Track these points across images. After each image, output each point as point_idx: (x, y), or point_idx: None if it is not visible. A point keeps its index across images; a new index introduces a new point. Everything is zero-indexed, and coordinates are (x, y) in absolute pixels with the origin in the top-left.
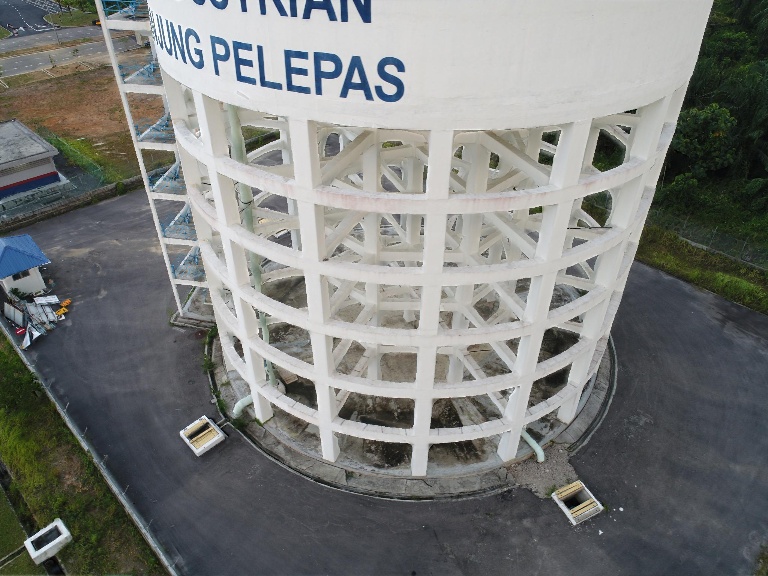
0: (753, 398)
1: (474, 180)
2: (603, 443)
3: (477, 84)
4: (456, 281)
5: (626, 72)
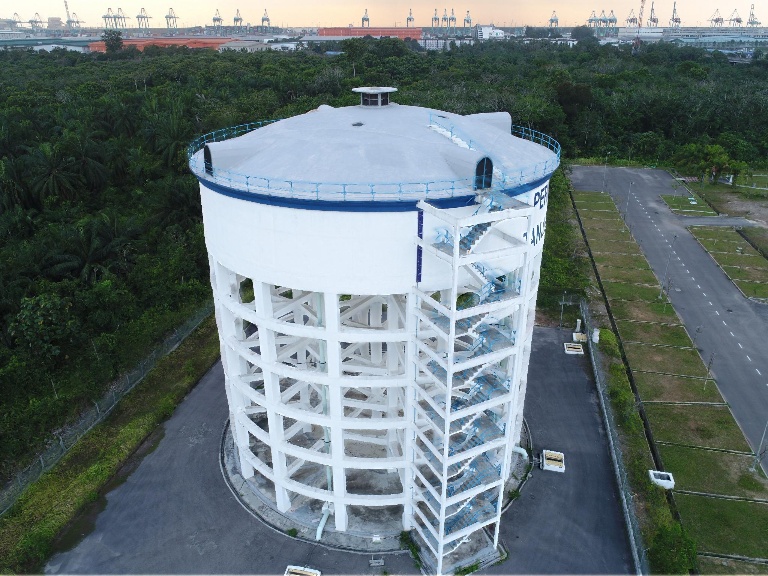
0: None
1: None
2: None
3: None
4: None
5: None
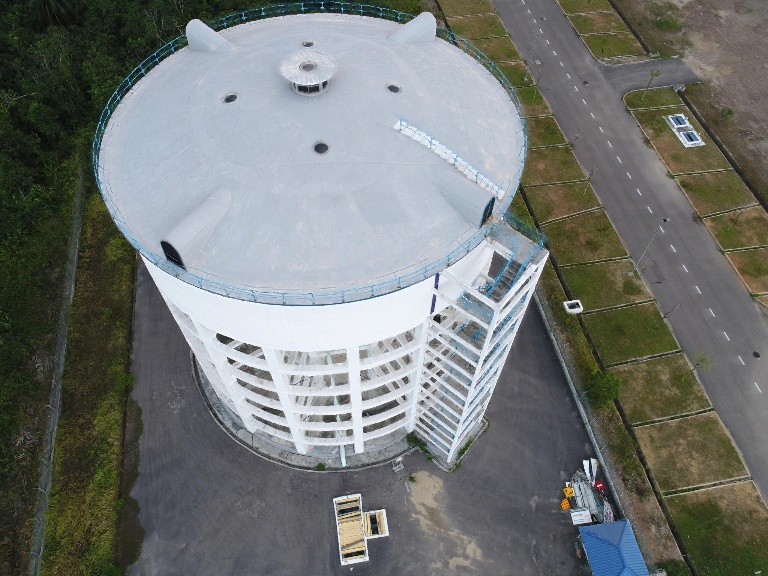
0: None
1: None
2: None
3: None
4: None
5: None
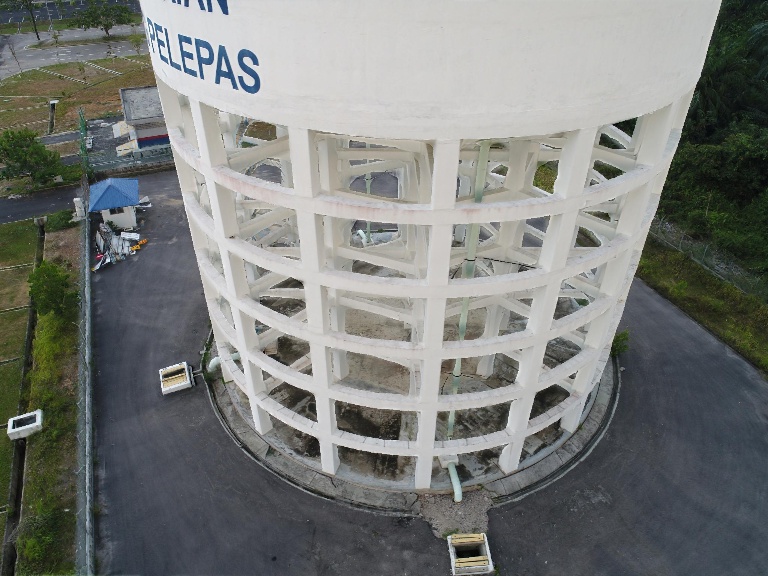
0: (757, 519)
1: (419, 191)
2: (537, 506)
3: (322, 85)
4: (333, 283)
5: (501, 94)
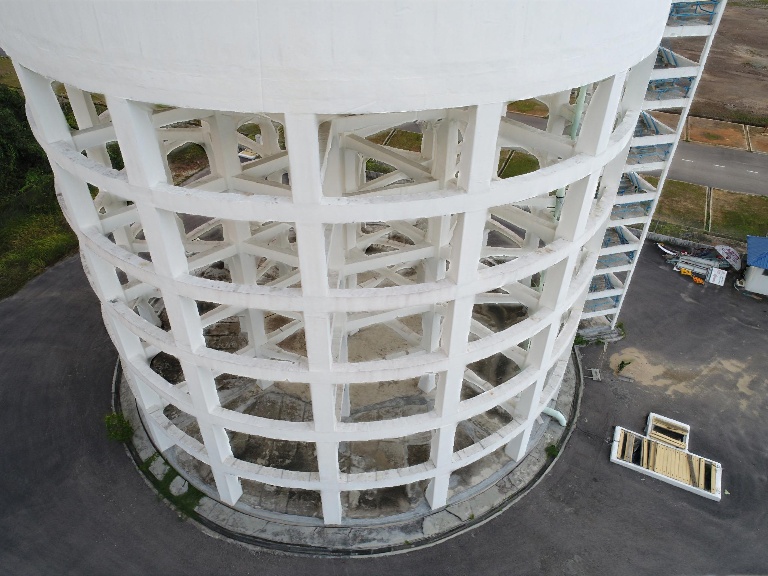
0: None
1: None
2: None
3: None
4: None
5: None
